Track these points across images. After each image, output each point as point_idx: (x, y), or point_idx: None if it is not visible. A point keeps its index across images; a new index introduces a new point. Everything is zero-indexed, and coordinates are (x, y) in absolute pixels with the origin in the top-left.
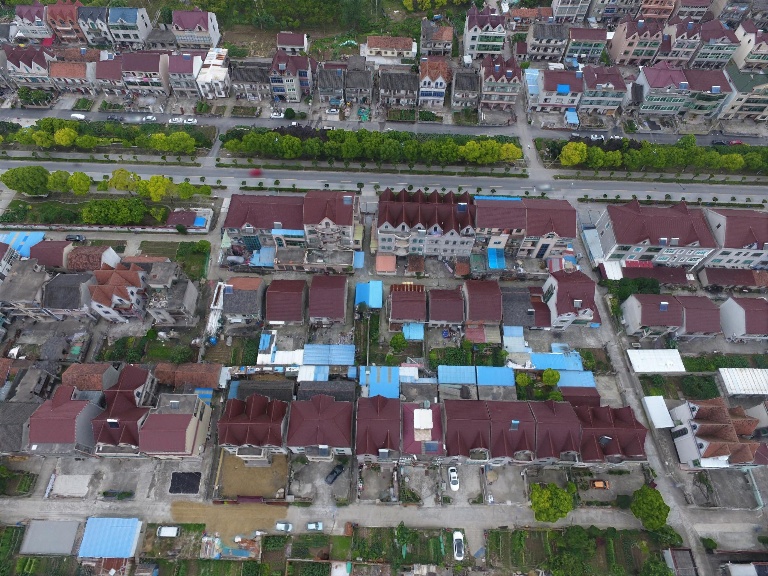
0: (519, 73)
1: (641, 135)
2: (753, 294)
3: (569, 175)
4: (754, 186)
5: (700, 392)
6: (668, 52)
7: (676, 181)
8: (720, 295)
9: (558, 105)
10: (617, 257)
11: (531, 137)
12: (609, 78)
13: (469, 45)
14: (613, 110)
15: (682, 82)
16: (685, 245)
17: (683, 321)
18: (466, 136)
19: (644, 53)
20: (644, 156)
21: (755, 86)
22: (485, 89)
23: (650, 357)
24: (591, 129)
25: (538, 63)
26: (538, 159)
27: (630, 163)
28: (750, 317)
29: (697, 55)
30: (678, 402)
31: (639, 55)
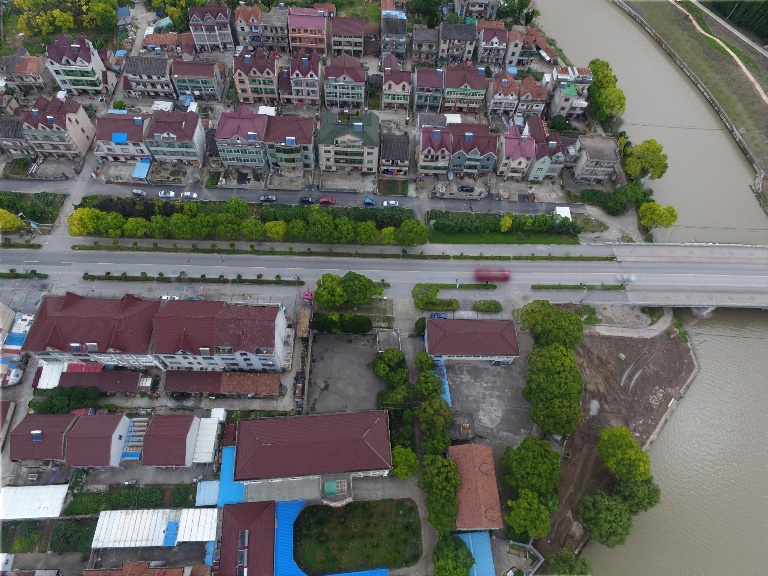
0: (63, 119)
1: (223, 191)
2: (227, 400)
3: (92, 245)
4: (308, 257)
5: (61, 546)
6: (290, 91)
7: (216, 252)
8: (185, 402)
9: (128, 155)
10: (56, 360)
11: (84, 194)
12: (169, 126)
13: (58, 79)
14: (196, 161)
15: (250, 132)
16: (105, 351)
17: (65, 452)
18: (2, 193)
19: (264, 91)
20: (169, 224)
21: (336, 137)
22: (27, 137)
23: (25, 497)
24: (165, 183)
25: (152, 100)
26: (68, 224)
27: (152, 232)
28: (150, 445)
29: (325, 94)
30: (42, 556)
31: (260, 93)
